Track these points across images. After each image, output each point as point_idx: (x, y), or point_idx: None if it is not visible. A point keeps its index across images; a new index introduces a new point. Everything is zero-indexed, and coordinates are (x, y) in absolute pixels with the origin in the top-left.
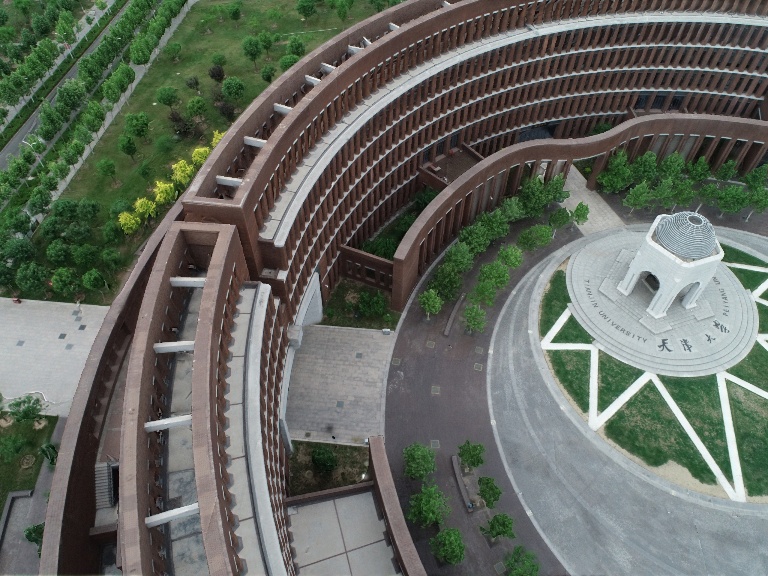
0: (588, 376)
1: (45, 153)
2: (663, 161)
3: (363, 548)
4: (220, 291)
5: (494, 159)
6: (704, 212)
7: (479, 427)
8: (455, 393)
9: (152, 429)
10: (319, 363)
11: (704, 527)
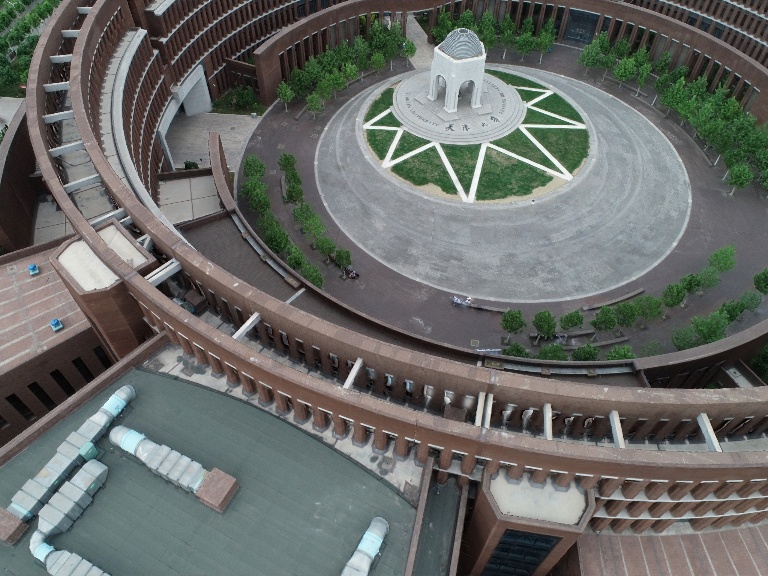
0: (391, 143)
1: (24, 14)
2: (480, 19)
3: (203, 198)
4: (104, 8)
5: (343, 5)
6: (510, 57)
7: (305, 165)
8: (294, 148)
9: (54, 61)
10: (204, 132)
11: (439, 213)
